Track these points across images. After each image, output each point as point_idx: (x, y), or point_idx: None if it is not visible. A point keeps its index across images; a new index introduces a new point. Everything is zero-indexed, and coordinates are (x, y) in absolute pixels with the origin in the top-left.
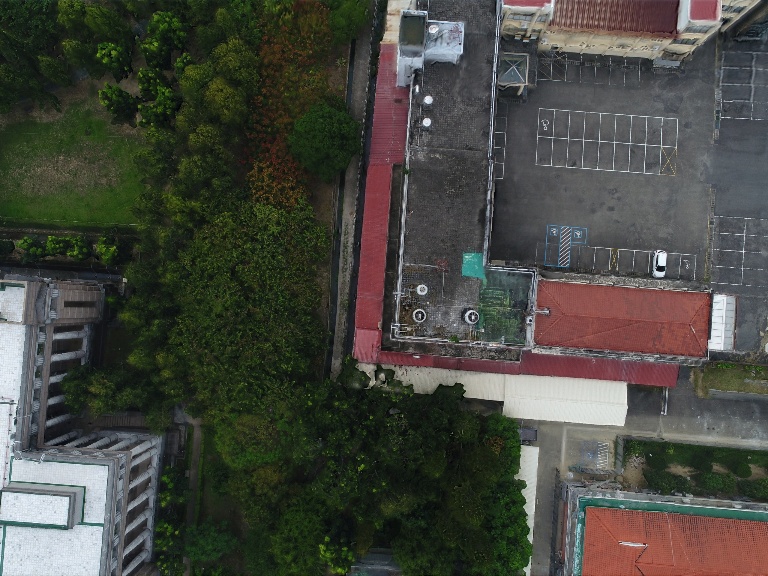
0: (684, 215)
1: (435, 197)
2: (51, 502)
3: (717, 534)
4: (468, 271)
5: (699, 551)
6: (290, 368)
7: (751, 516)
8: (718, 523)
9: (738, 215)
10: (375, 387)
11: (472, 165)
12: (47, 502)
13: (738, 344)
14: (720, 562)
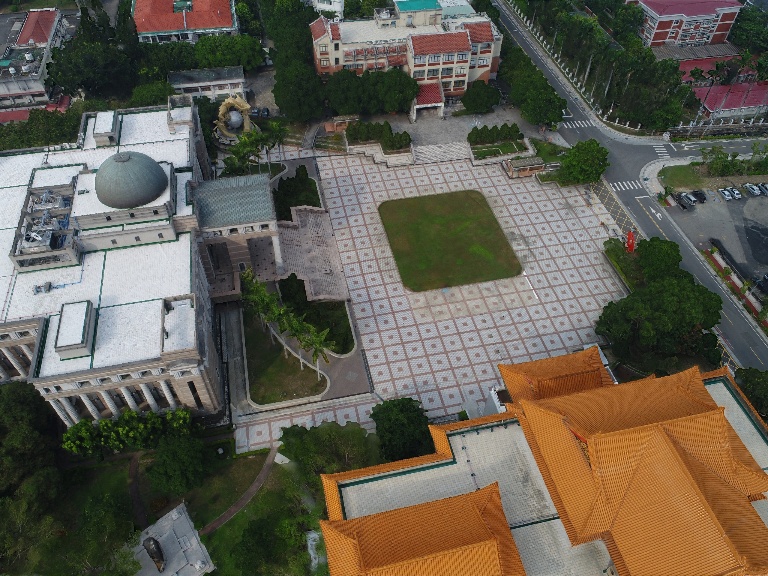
0: (4, 50)
1: None
2: (100, 118)
3: (140, 6)
4: (6, 64)
5: (146, 6)
6: (56, 110)
7: (134, 4)
8: (136, 8)
9: (7, 39)
10: None
11: None
12: (100, 119)
13: (70, 32)
14: (149, 1)
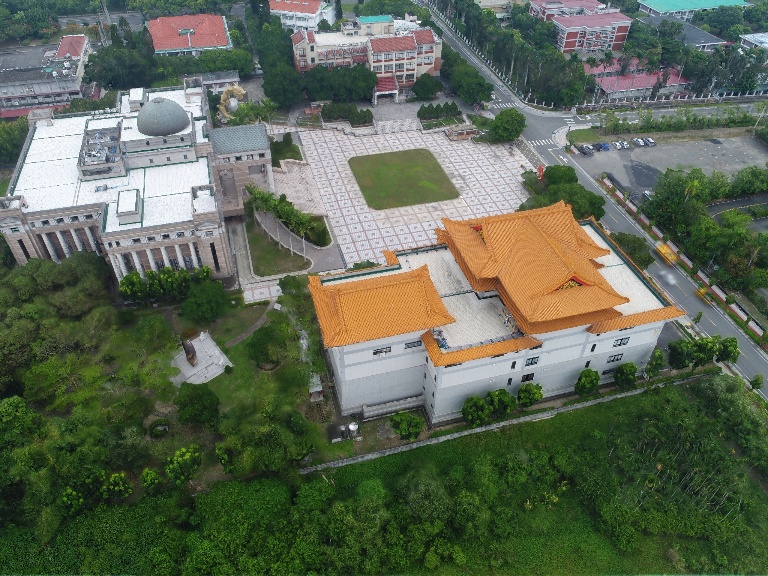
0: None
1: (15, 79)
2: None
3: None
4: None
5: None
6: None
7: None
8: None
9: None
10: (89, 61)
11: (2, 75)
12: None
13: None
14: None
